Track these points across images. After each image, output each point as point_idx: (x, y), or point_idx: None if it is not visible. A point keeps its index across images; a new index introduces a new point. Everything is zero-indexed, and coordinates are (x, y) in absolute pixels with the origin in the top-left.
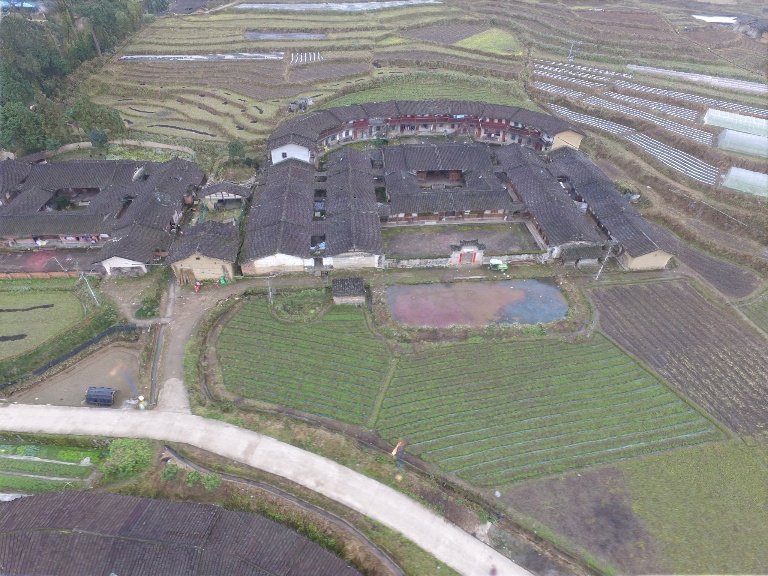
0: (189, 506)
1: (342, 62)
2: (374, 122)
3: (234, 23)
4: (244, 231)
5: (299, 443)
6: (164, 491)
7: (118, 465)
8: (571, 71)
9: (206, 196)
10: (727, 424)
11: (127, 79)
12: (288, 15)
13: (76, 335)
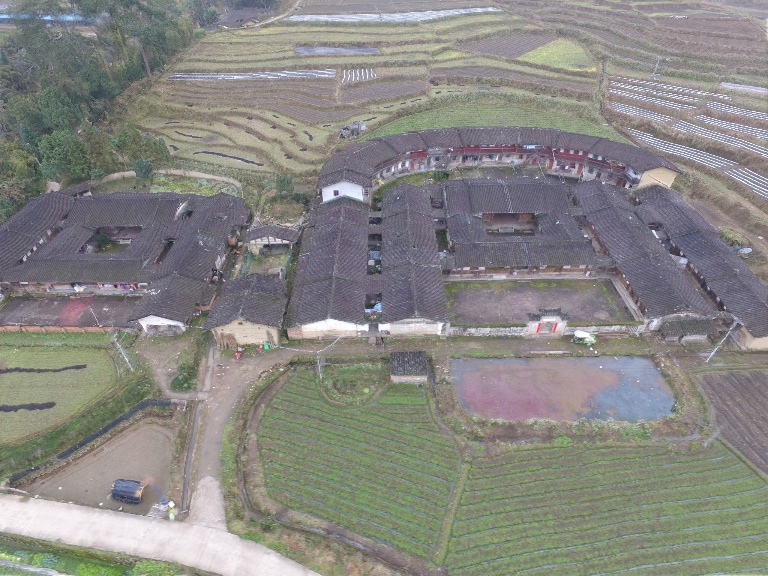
0: None
1: (396, 80)
2: (433, 152)
3: (284, 37)
4: (291, 282)
5: None
6: None
7: None
8: (654, 90)
9: (251, 241)
10: None
11: (175, 100)
12: (340, 27)
13: (106, 409)
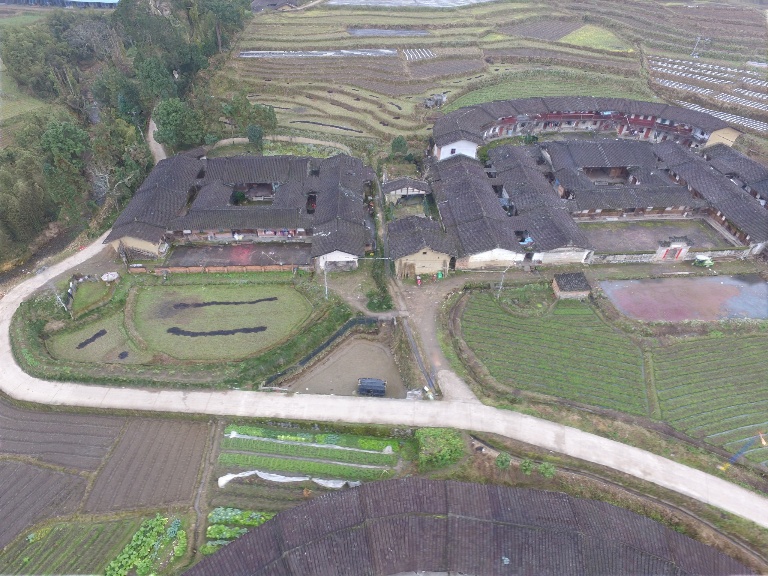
0: (538, 493)
1: (455, 59)
2: (521, 119)
3: (333, 19)
4: None
5: (605, 434)
6: (492, 479)
7: (436, 453)
8: (691, 68)
9: (392, 191)
10: None
11: (251, 75)
12: (381, 11)
13: (323, 327)
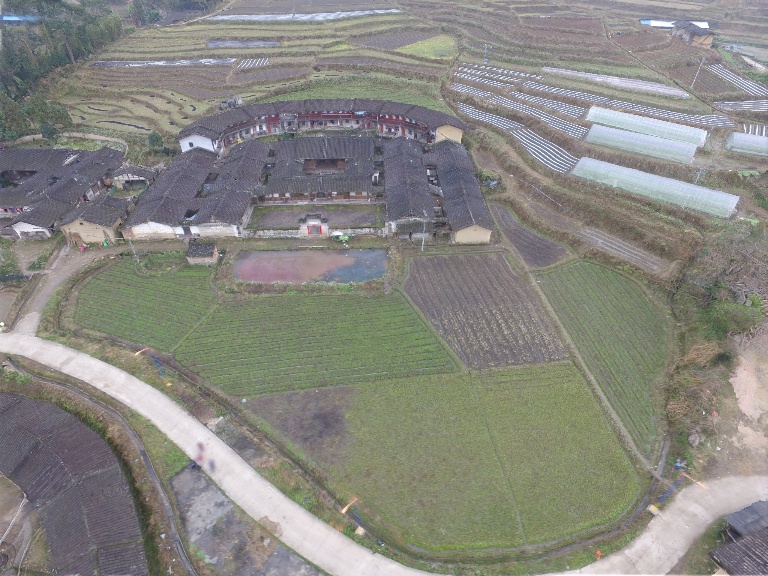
0: (1, 394)
1: (286, 67)
2: (285, 118)
3: (202, 33)
4: None
5: (106, 359)
6: None
7: None
8: (489, 73)
9: (115, 177)
10: (465, 361)
11: (93, 82)
12: (254, 25)
13: None
